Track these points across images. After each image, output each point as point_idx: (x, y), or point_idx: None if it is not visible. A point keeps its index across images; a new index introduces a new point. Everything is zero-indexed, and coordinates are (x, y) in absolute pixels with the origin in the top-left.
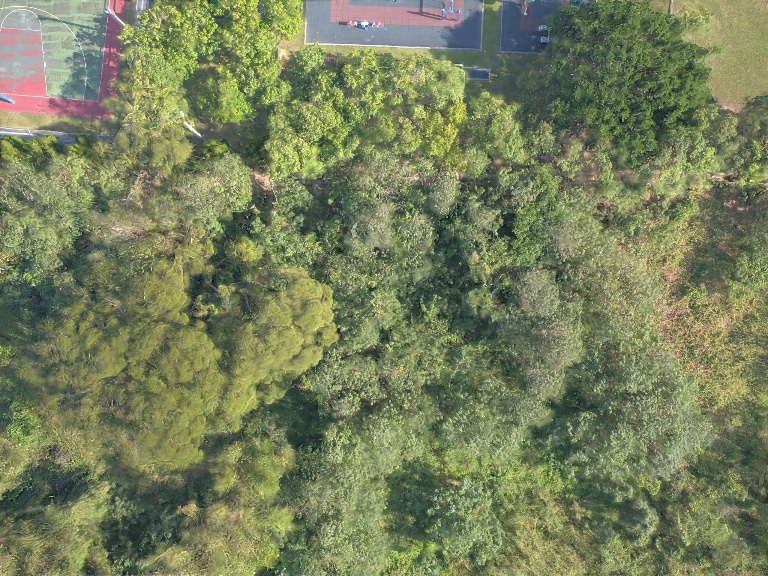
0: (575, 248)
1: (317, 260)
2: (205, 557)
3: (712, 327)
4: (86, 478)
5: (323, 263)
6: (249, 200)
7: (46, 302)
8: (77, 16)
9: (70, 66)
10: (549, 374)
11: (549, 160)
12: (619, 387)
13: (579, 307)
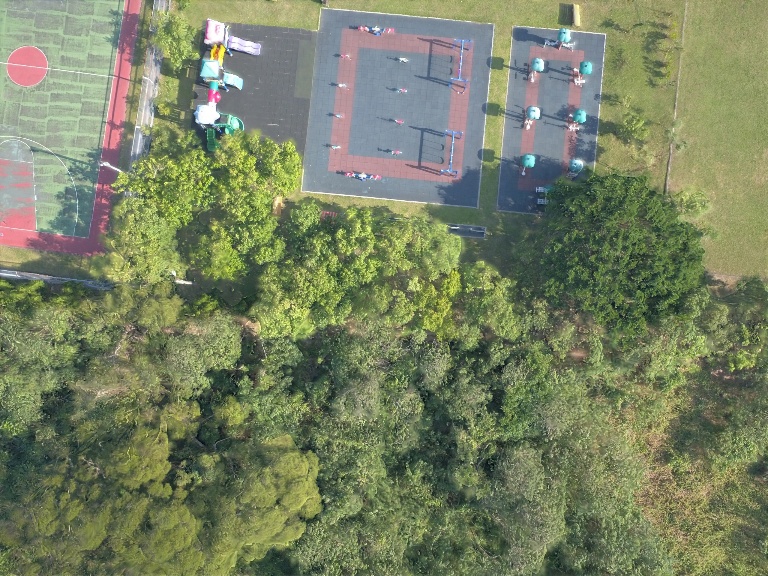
0: (562, 428)
1: (304, 419)
2: None
3: (694, 495)
4: None
5: (310, 420)
6: (238, 358)
7: (27, 445)
8: (71, 150)
9: (61, 201)
10: (531, 554)
11: (541, 338)
12: (600, 564)
13: (564, 488)
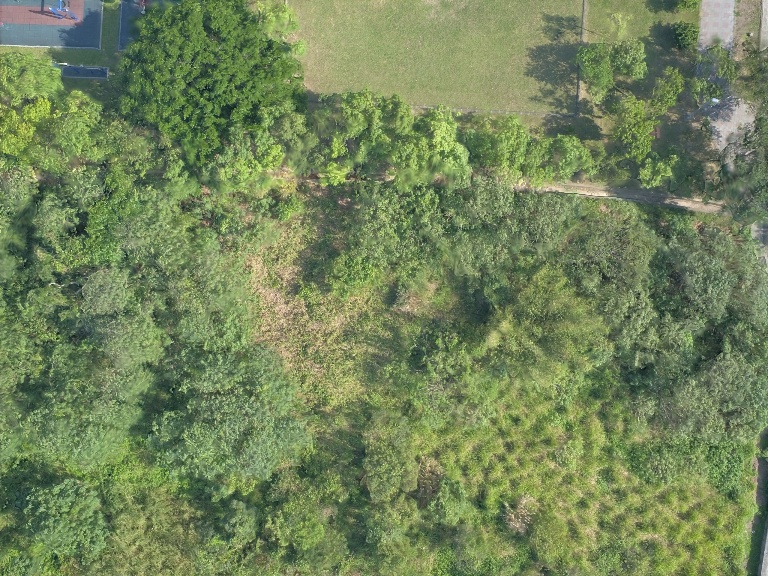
0: (146, 246)
1: None
2: None
3: (325, 326)
4: None
5: None
6: None
7: None
8: None
9: None
10: (115, 373)
11: (125, 158)
12: (200, 386)
13: (148, 306)
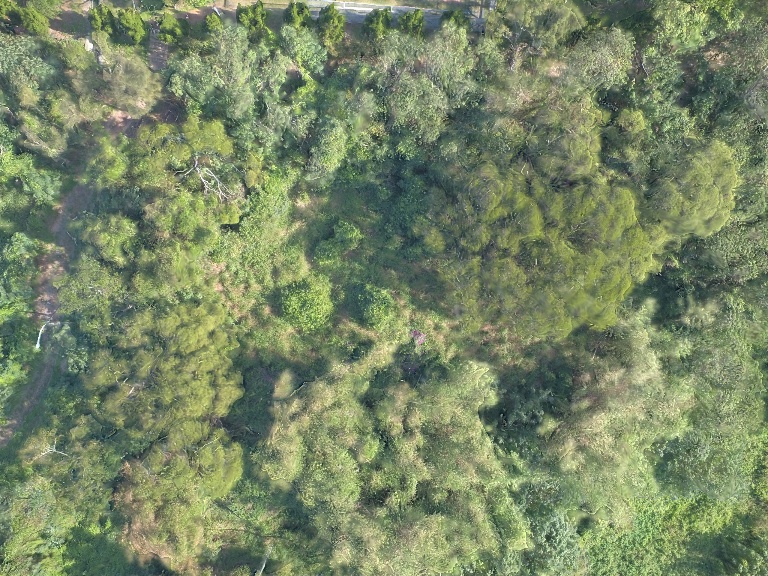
0: None
1: None
2: (619, 420)
3: None
4: (441, 361)
5: None
6: None
7: (404, 181)
8: None
9: None
10: None
11: None
12: None
13: None
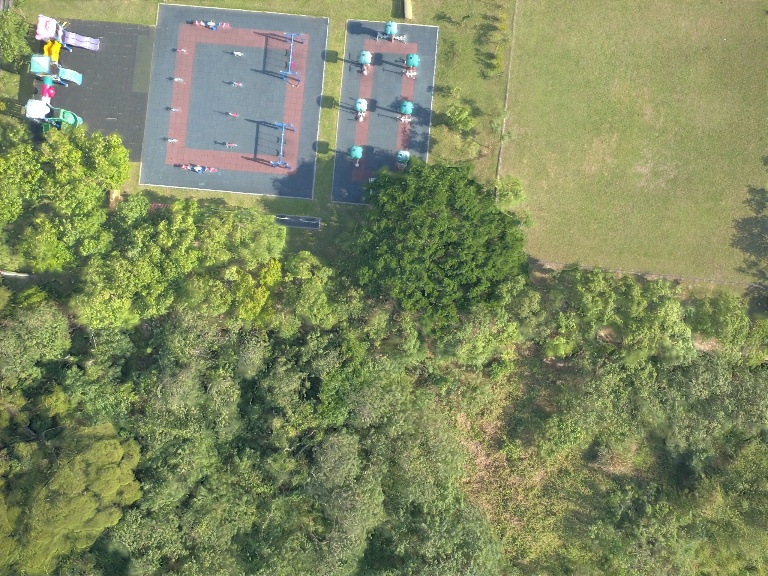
0: (378, 414)
1: (134, 408)
2: None
3: (526, 481)
4: None
5: (142, 409)
6: (66, 348)
7: None
8: None
9: None
10: (346, 539)
11: (358, 325)
12: (421, 548)
13: (379, 473)
